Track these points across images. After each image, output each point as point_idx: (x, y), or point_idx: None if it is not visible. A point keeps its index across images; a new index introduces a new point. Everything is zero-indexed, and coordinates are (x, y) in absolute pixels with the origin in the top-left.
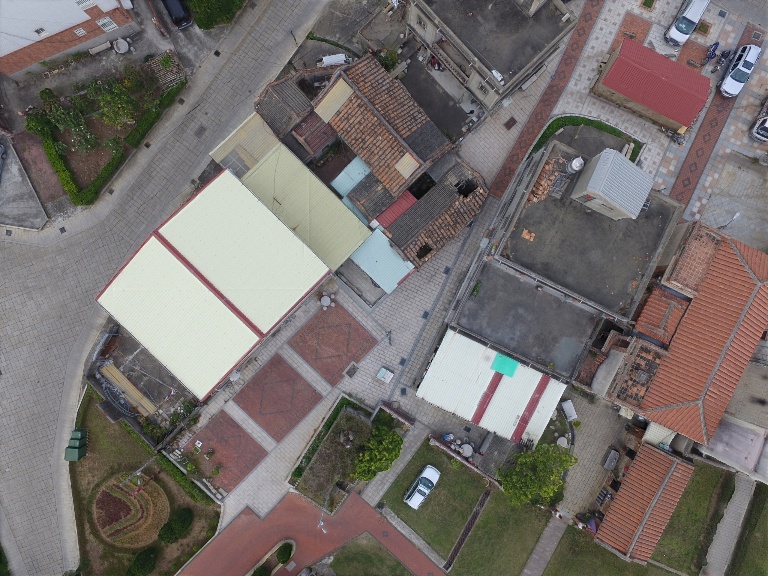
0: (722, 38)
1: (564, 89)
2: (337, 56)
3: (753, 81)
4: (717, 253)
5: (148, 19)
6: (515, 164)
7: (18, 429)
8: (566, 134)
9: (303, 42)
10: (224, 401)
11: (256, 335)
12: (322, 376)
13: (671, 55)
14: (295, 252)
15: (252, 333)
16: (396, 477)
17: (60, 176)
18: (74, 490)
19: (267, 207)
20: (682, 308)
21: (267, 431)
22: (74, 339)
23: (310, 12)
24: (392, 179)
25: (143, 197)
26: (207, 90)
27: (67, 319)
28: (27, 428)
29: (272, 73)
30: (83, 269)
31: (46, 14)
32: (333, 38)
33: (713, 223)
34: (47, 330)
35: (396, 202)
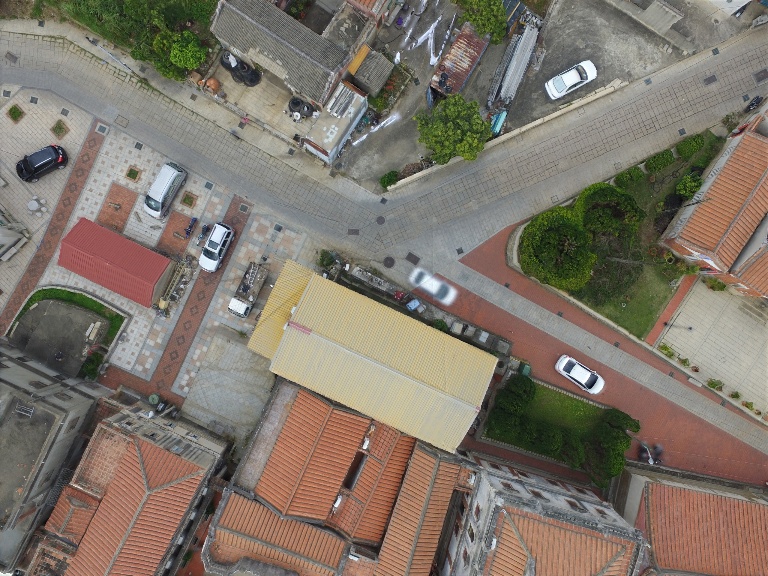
0: (209, 210)
1: (50, 260)
2: None
3: (241, 254)
4: (125, 454)
5: None
6: (2, 334)
7: None
8: (41, 309)
9: None
10: None
11: None
12: None
13: (155, 227)
14: None
15: None
16: None
17: None
18: None
19: None
20: (91, 509)
21: None
22: None
23: None
24: None
25: None
26: None
27: None
28: None
29: None
30: None
31: None
32: None
33: (202, 397)
34: None
35: None
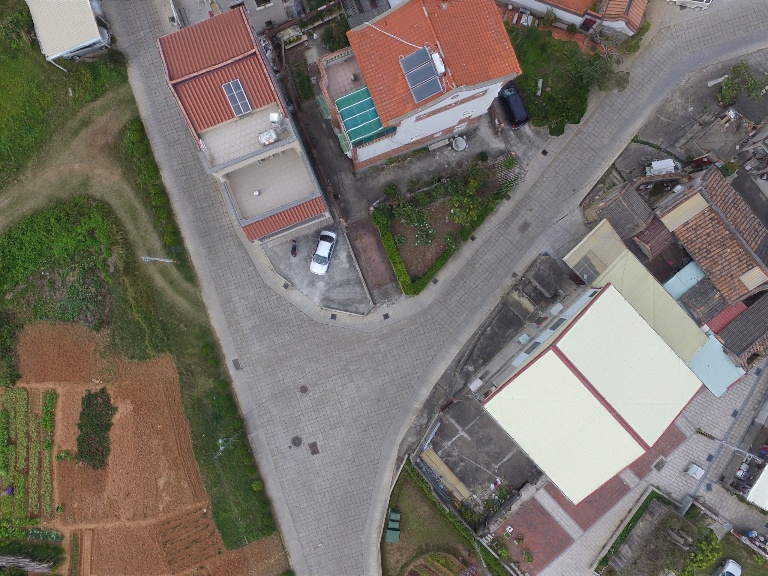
0: None
1: None
2: (665, 161)
3: None
4: None
5: (482, 117)
6: None
7: (332, 506)
8: None
9: (628, 145)
10: (536, 489)
11: (643, 448)
12: (631, 468)
13: None
14: (673, 367)
15: (639, 446)
16: (695, 569)
17: (396, 267)
18: (384, 568)
19: (647, 322)
20: None
21: (575, 519)
22: (390, 422)
23: (637, 116)
24: (733, 289)
25: (465, 288)
26: (533, 187)
27: (385, 402)
28: (341, 506)
29: (596, 173)
30: (403, 354)
31: (434, 125)
32: (656, 142)
33: None
34: (365, 412)
35: (726, 308)
